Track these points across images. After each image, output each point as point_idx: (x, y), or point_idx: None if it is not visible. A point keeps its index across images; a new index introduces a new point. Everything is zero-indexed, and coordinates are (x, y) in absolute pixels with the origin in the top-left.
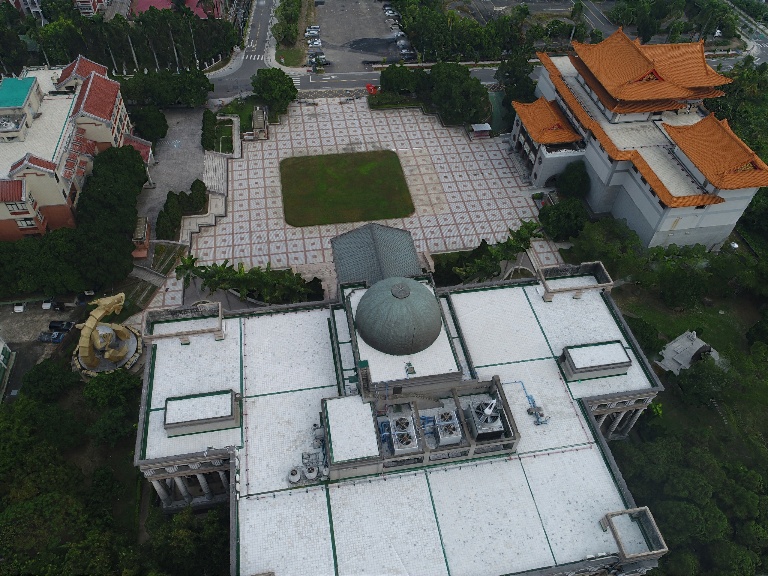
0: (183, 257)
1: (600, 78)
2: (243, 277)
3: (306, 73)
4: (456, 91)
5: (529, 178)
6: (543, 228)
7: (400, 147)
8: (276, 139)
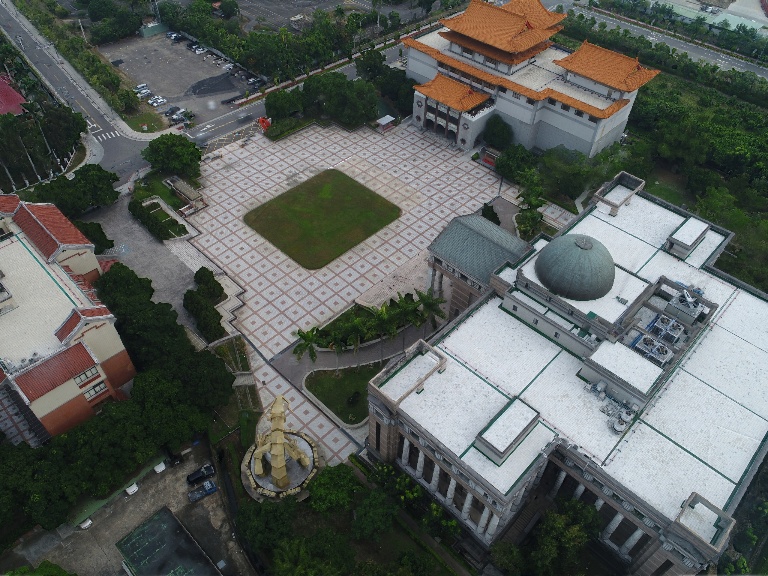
0: (301, 333)
1: (487, 41)
2: (387, 316)
3: (179, 132)
4: (353, 95)
5: (456, 146)
6: (501, 179)
7: (334, 163)
8: (216, 202)
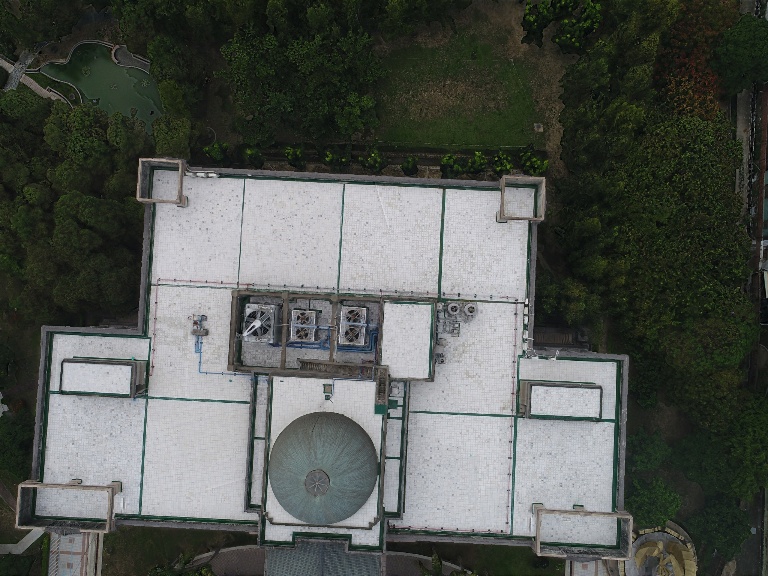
0: None
1: None
2: None
3: None
4: None
5: None
6: None
7: None
8: None
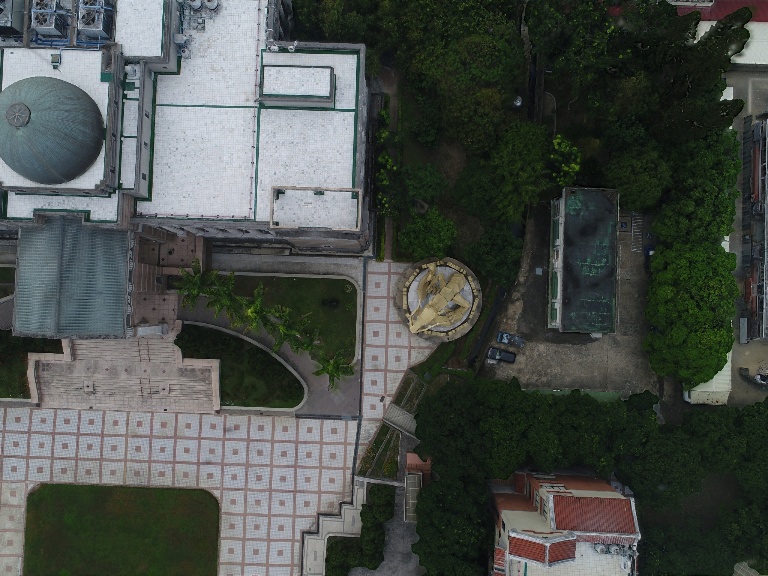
0: None
1: None
2: None
3: None
4: None
5: None
6: None
7: None
8: None
